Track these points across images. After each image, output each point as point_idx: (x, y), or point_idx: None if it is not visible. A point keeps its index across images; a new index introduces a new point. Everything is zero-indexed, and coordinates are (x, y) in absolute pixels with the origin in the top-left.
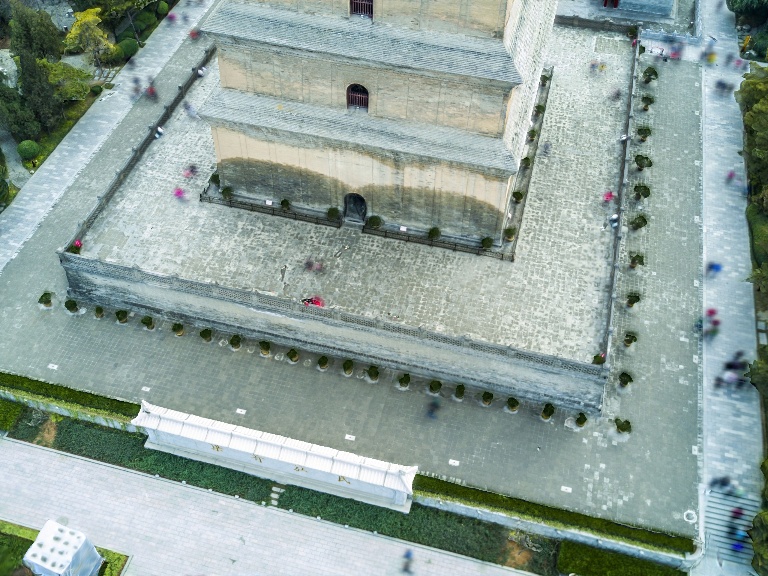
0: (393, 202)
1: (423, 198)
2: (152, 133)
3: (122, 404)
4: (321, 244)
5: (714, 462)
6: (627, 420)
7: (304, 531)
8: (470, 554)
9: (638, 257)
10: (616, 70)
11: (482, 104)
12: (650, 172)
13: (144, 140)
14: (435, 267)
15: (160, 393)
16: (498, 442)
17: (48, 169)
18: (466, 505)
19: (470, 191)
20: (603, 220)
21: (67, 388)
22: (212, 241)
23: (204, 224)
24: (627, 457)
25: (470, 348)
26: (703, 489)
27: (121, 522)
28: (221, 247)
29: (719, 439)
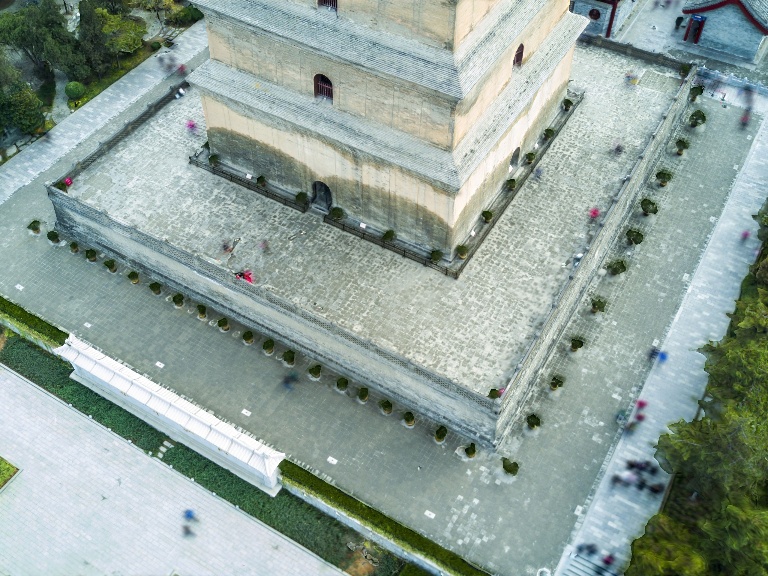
0: (354, 197)
1: (380, 198)
2: (172, 93)
3: (60, 333)
4: (281, 225)
5: (593, 527)
6: (521, 463)
7: (176, 488)
8: (316, 551)
9: (599, 302)
10: (652, 107)
11: (432, 114)
12: (656, 219)
13: (162, 98)
14: (378, 268)
15: (98, 331)
16: (382, 452)
17: (86, 111)
18: (326, 503)
19: (421, 200)
20: (568, 257)
21: (21, 308)
22: (184, 202)
23: (184, 185)
24: (504, 499)
25: (376, 353)
26: (569, 551)
27: (25, 438)
28: (190, 209)
29: (609, 506)
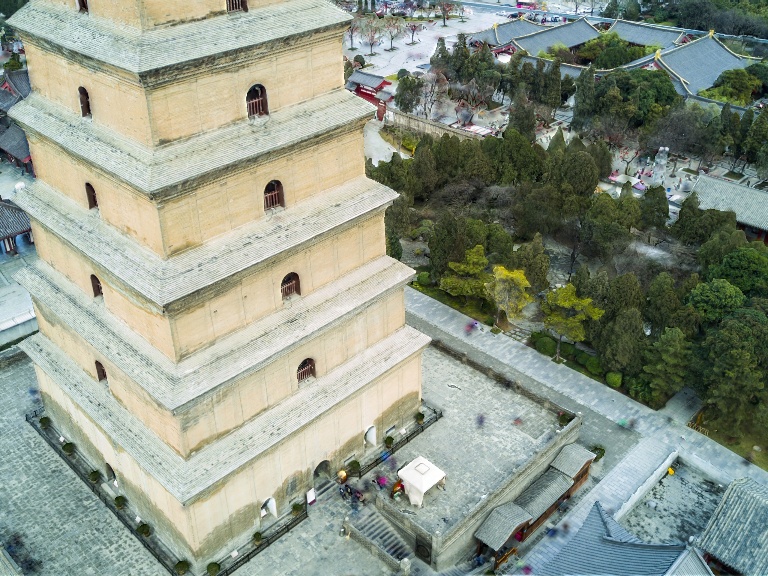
0: None
1: None
2: None
3: None
4: None
5: None
6: None
7: None
8: None
9: None
10: None
11: None
12: None
13: None
14: None
15: None
16: None
17: None
18: None
19: None
20: None
21: None
22: None
23: None
24: None
25: None
26: None
27: None
28: None
29: None
